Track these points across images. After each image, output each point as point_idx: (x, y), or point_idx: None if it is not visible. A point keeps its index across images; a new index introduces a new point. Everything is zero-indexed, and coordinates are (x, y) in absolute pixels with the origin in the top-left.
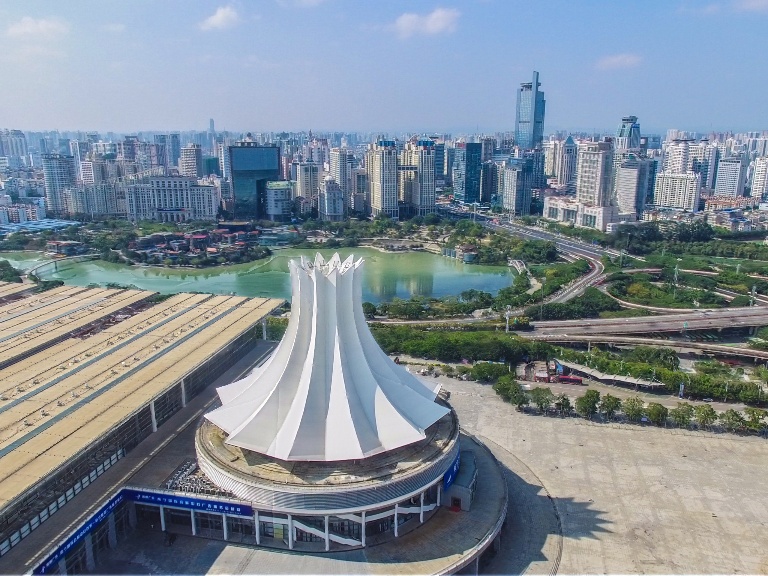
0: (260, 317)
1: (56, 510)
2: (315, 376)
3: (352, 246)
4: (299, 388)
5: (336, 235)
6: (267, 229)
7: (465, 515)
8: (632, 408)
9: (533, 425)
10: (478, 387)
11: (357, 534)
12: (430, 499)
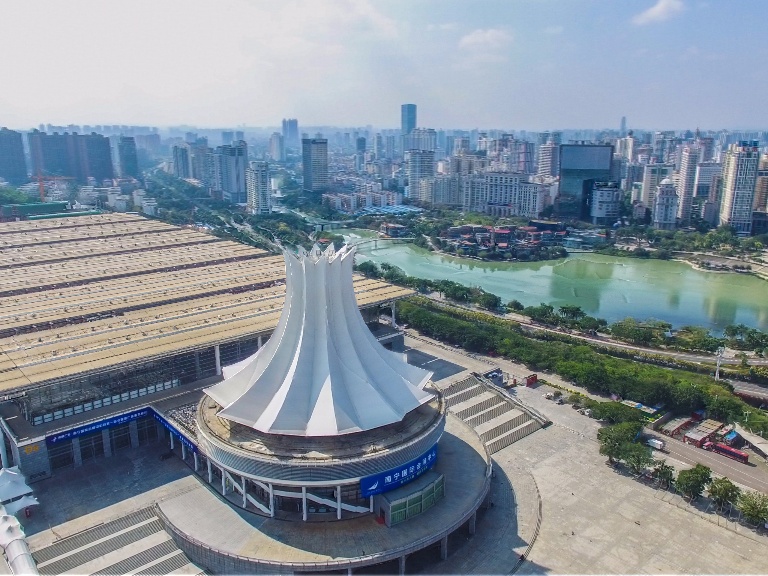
0: (369, 302)
1: (101, 406)
2: (281, 352)
3: (663, 258)
4: None
5: (651, 244)
6: (577, 231)
7: (382, 529)
8: (752, 505)
9: (606, 483)
10: (593, 426)
11: (275, 504)
12: (367, 502)
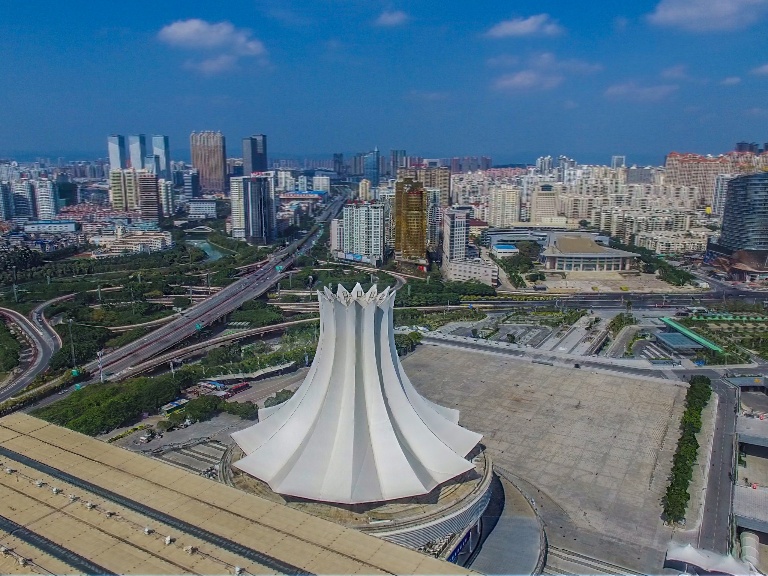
0: None
1: None
2: None
3: None
4: (398, 420)
5: None
6: None
7: None
8: None
9: None
10: (212, 423)
11: None
12: None
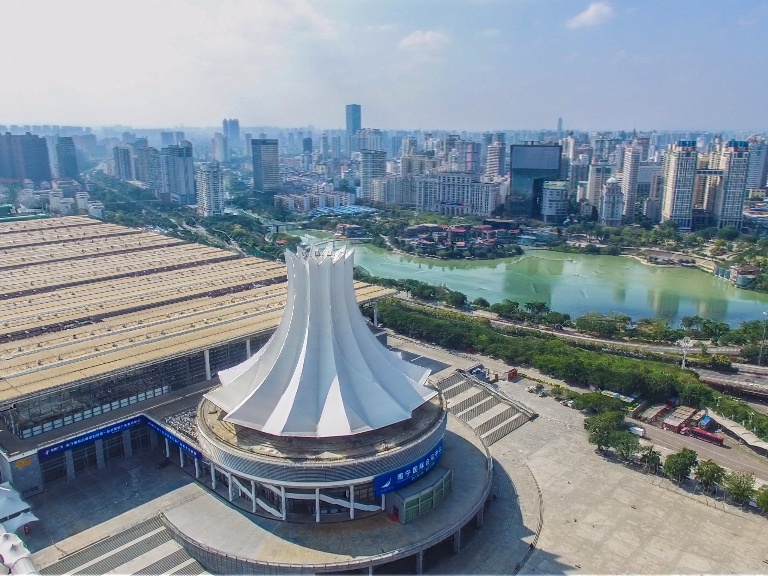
0: None
1: (91, 416)
2: (285, 354)
3: (613, 254)
4: None
5: (600, 241)
6: (530, 229)
7: (396, 526)
8: (737, 485)
9: (598, 471)
10: (577, 417)
11: (285, 507)
12: (378, 501)
